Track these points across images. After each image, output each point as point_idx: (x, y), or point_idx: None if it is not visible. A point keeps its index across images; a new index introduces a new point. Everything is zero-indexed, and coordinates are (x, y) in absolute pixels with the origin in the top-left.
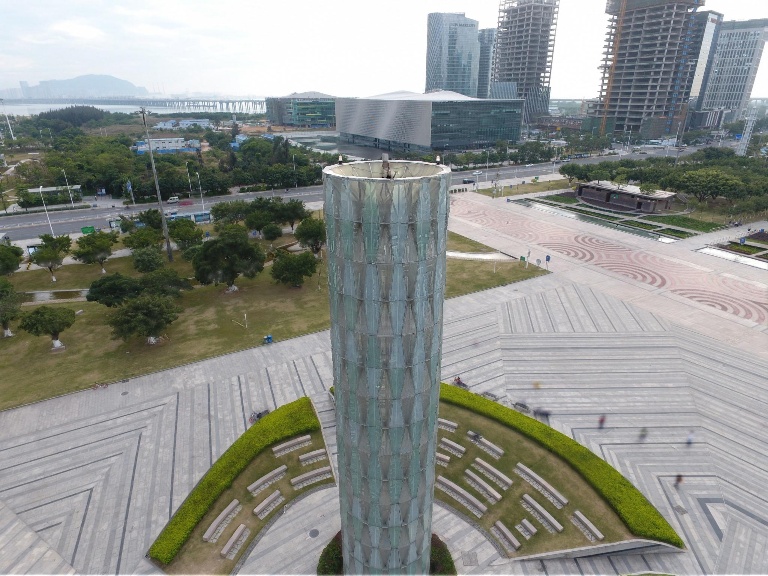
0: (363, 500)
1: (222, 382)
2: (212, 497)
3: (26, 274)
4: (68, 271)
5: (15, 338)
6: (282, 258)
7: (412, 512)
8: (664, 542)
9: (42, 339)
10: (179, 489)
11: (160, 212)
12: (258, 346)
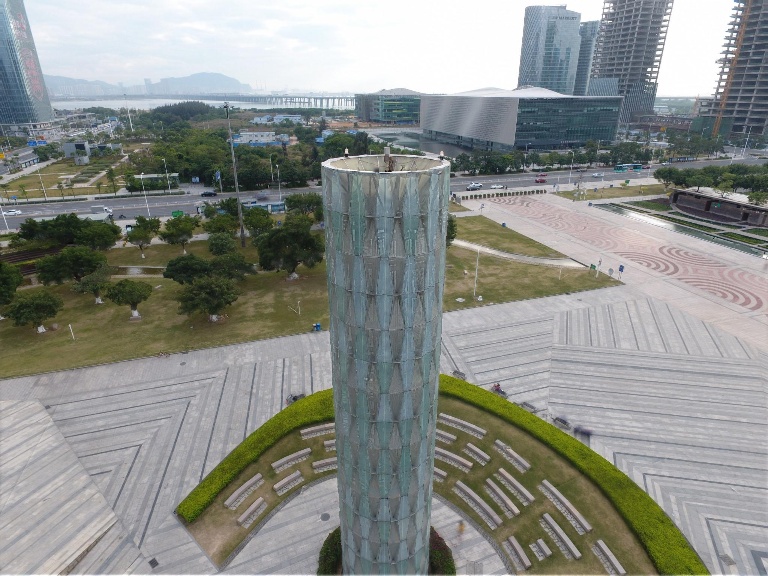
0: (354, 490)
1: (268, 363)
2: (238, 468)
3: (122, 250)
4: (156, 250)
5: (103, 305)
6: None
7: (403, 510)
8: None
9: (124, 308)
10: (213, 456)
11: None
12: (307, 333)
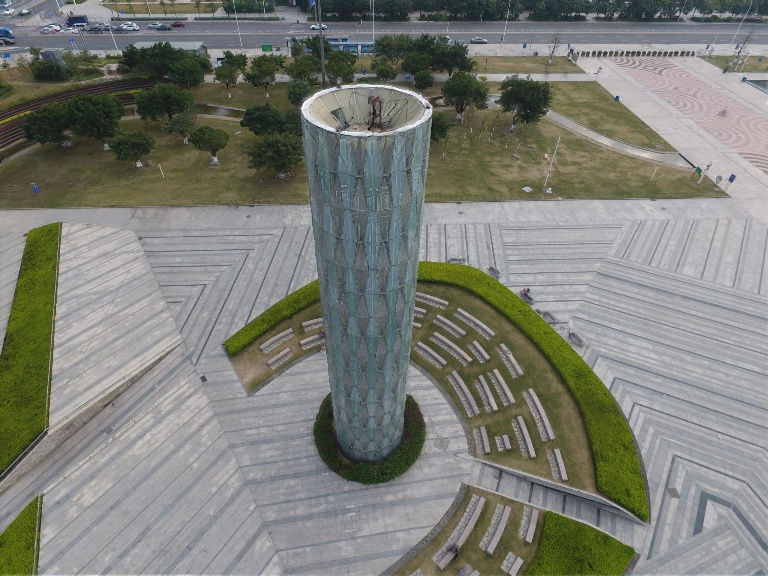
0: (334, 374)
1: None
2: (274, 321)
3: (212, 86)
4: (242, 89)
5: (190, 147)
6: None
7: (372, 397)
8: (626, 509)
9: (207, 152)
10: (258, 306)
11: (326, 39)
12: None
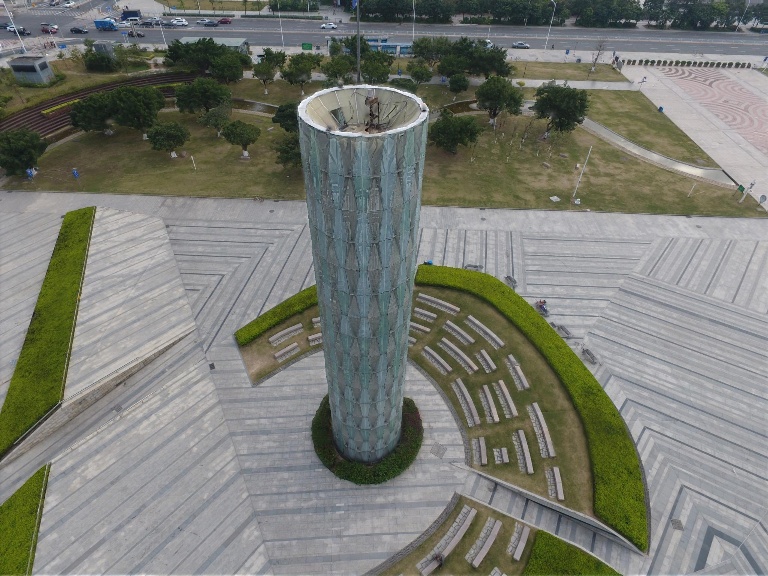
0: (329, 372)
1: None
2: (285, 315)
3: (250, 82)
4: (279, 86)
5: (223, 140)
6: (445, 119)
7: (365, 397)
8: (624, 537)
9: (239, 146)
10: (272, 299)
11: (365, 40)
12: None
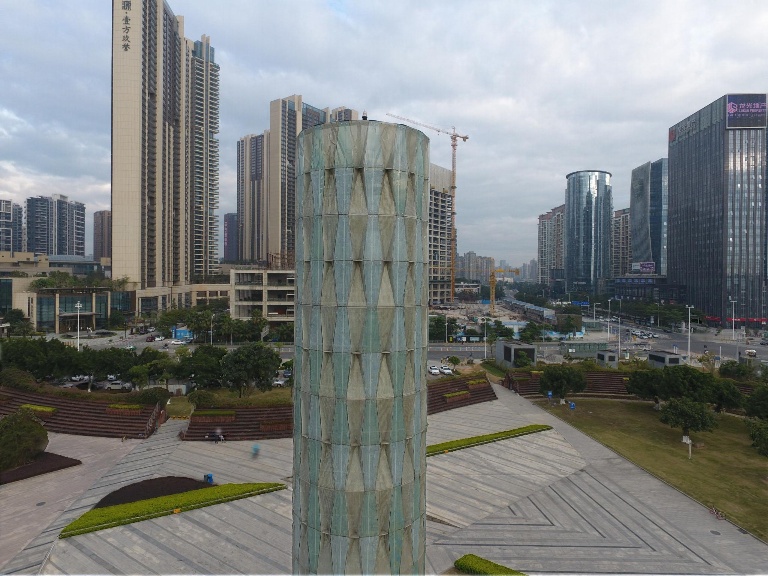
0: None
1: None
2: None
3: None
4: None
5: None
6: None
7: None
8: None
9: None
10: None
11: None
12: None
